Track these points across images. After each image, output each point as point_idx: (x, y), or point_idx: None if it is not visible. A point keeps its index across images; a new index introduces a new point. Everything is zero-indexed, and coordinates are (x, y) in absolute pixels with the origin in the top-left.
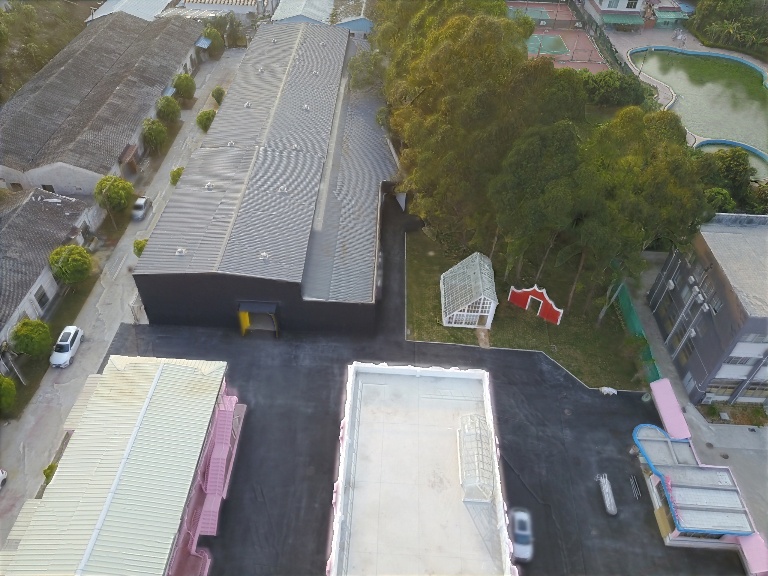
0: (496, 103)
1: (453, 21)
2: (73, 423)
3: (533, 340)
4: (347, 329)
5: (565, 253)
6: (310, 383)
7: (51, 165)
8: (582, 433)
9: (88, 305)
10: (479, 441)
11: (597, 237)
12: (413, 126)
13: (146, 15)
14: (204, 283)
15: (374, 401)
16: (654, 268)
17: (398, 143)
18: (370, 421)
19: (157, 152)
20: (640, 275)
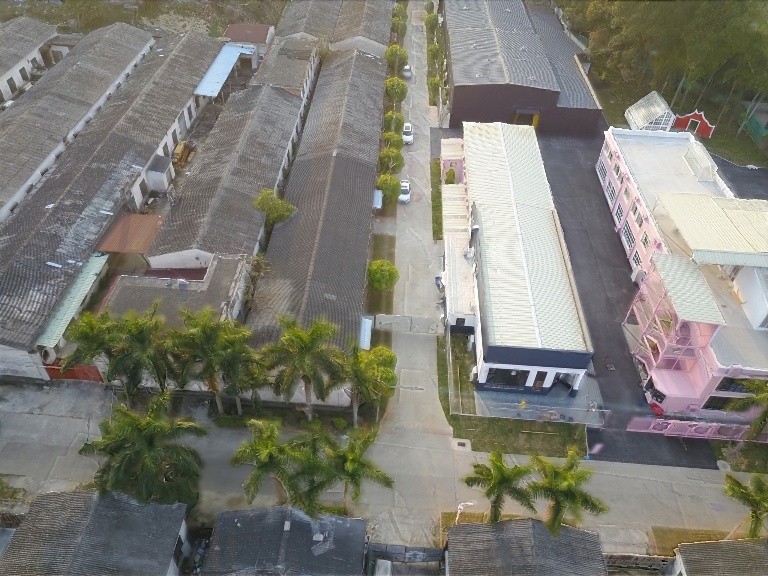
0: None
1: None
2: (447, 157)
3: None
4: (578, 131)
5: (730, 72)
6: (565, 156)
7: (353, 39)
8: (741, 184)
9: (404, 118)
10: (704, 151)
11: (759, 52)
12: None
13: None
14: (498, 93)
15: (628, 145)
16: (765, 115)
17: (577, 34)
18: (630, 152)
19: (398, 43)
20: (756, 118)
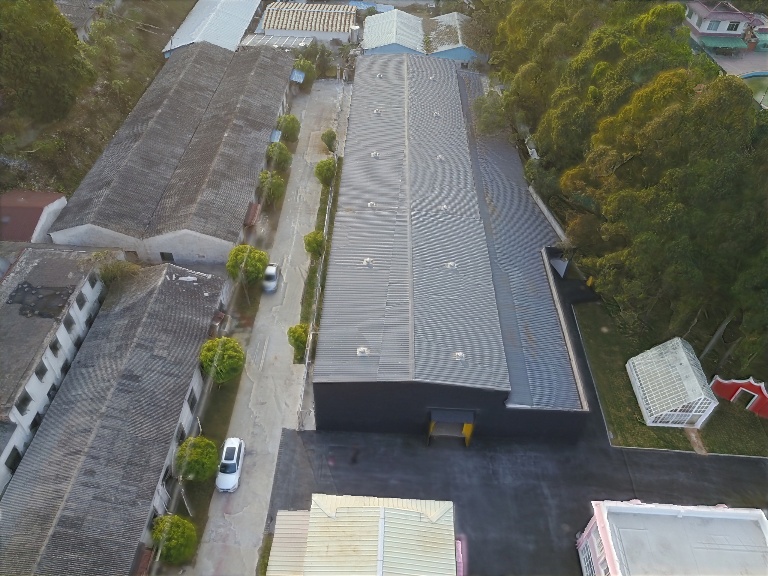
0: (747, 181)
1: (669, 78)
2: None
3: (752, 442)
4: (546, 435)
5: None
6: (521, 508)
7: (175, 232)
8: None
9: (240, 405)
10: None
11: None
12: (622, 200)
13: (227, 44)
14: (395, 391)
15: (640, 554)
16: None
17: (548, 199)
18: None
19: (272, 207)
20: None
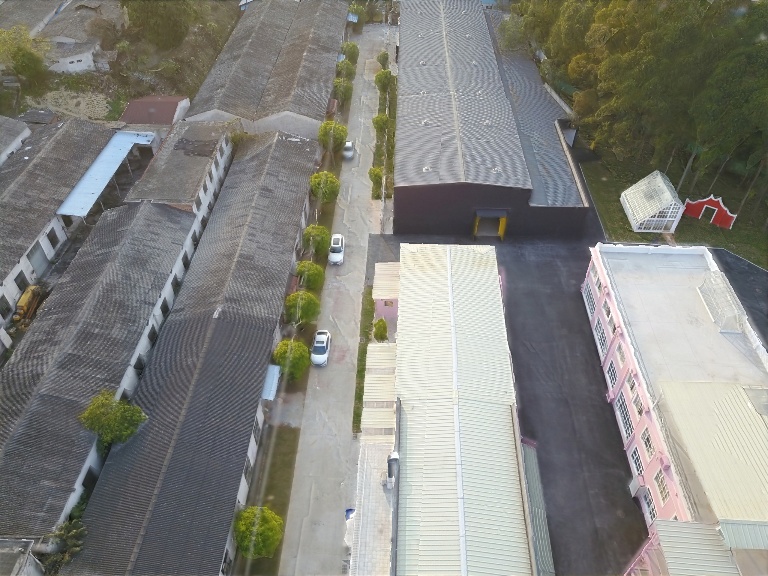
0: (697, 34)
1: None
2: (380, 294)
3: (713, 241)
4: (559, 233)
5: (756, 156)
6: (541, 272)
7: (278, 114)
8: None
9: (337, 222)
10: (727, 287)
11: None
12: (611, 61)
13: None
14: (451, 193)
15: (621, 270)
16: None
17: (559, 90)
18: (624, 283)
19: (343, 107)
20: None
